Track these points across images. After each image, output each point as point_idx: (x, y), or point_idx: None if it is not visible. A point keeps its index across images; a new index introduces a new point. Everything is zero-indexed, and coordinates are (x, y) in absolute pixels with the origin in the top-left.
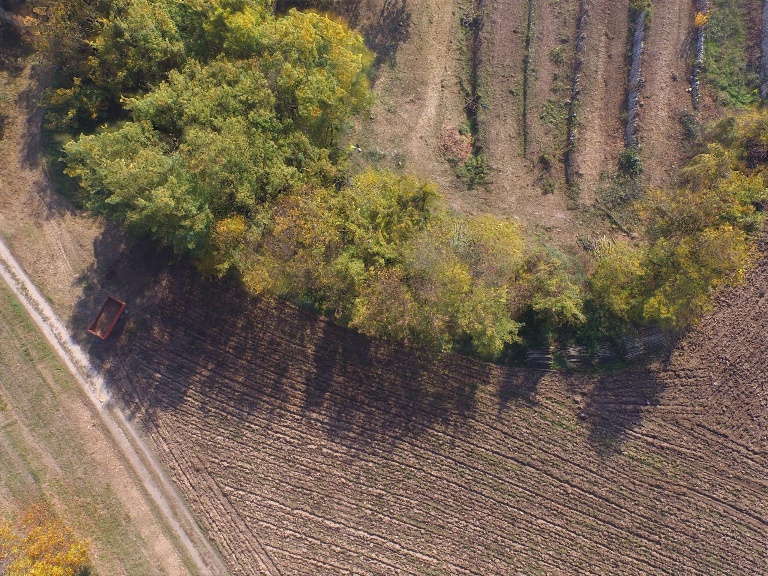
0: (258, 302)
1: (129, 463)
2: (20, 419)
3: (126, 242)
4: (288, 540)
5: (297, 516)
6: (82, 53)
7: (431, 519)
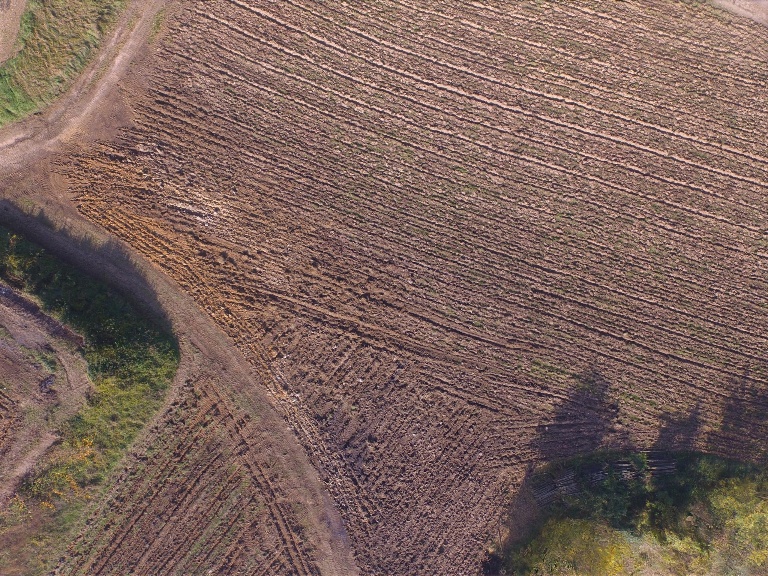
0: None
1: None
2: None
3: None
4: None
5: None
6: None
7: (765, 294)
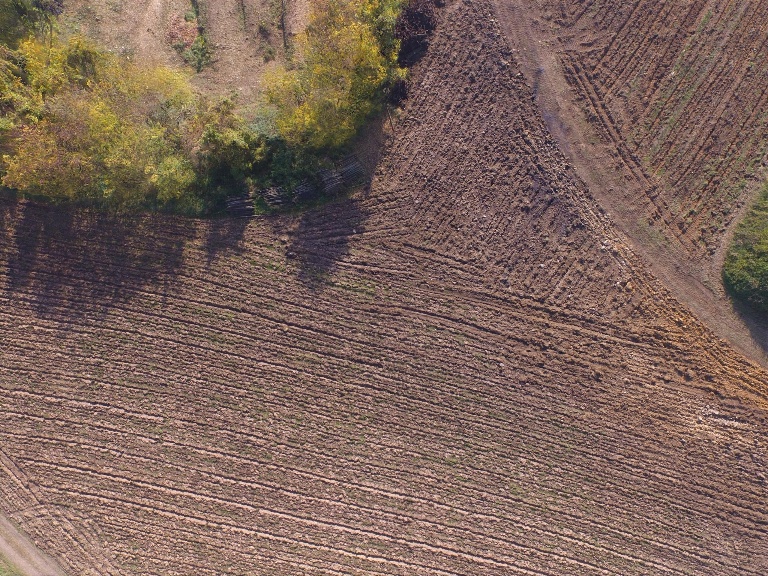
0: None
1: None
2: None
3: None
4: (11, 422)
5: (17, 397)
6: None
7: (152, 379)
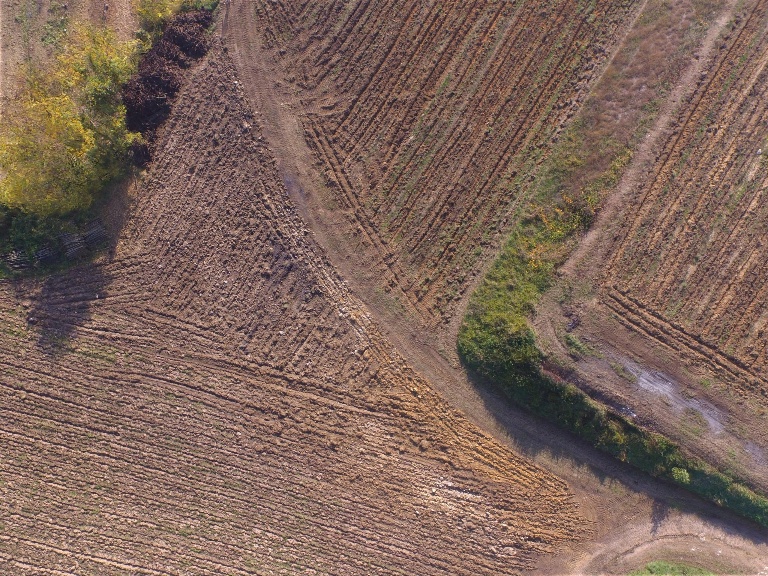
0: None
1: None
2: None
3: None
4: None
5: None
6: None
7: None
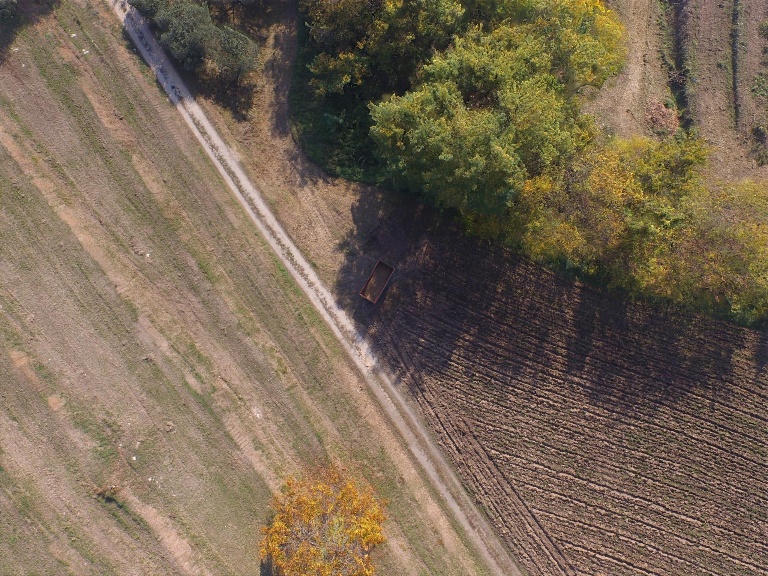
0: (516, 268)
1: (396, 427)
2: (299, 382)
3: (384, 208)
4: (554, 503)
5: (562, 479)
6: (364, 18)
7: (693, 481)
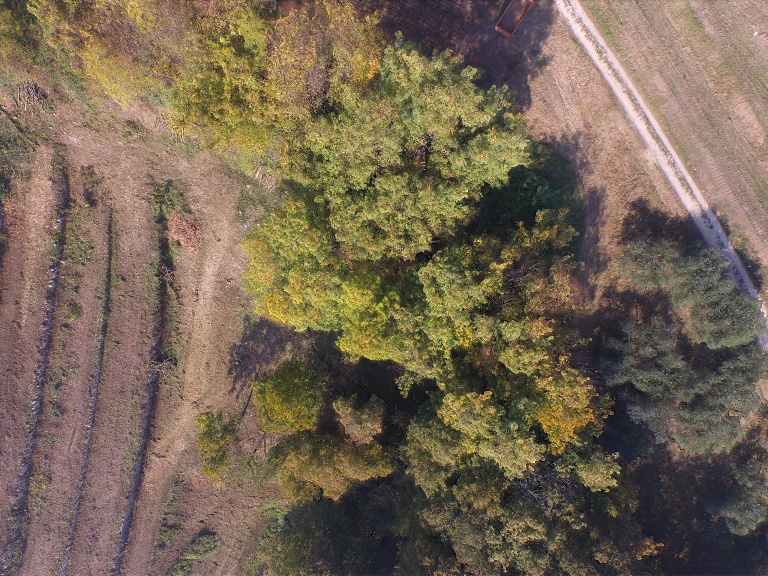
0: None
1: None
2: None
3: None
4: None
5: None
6: None
7: None
